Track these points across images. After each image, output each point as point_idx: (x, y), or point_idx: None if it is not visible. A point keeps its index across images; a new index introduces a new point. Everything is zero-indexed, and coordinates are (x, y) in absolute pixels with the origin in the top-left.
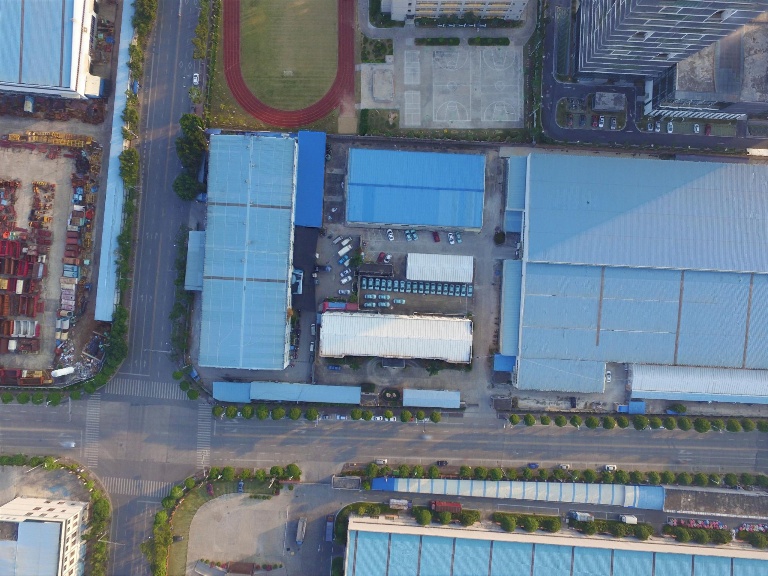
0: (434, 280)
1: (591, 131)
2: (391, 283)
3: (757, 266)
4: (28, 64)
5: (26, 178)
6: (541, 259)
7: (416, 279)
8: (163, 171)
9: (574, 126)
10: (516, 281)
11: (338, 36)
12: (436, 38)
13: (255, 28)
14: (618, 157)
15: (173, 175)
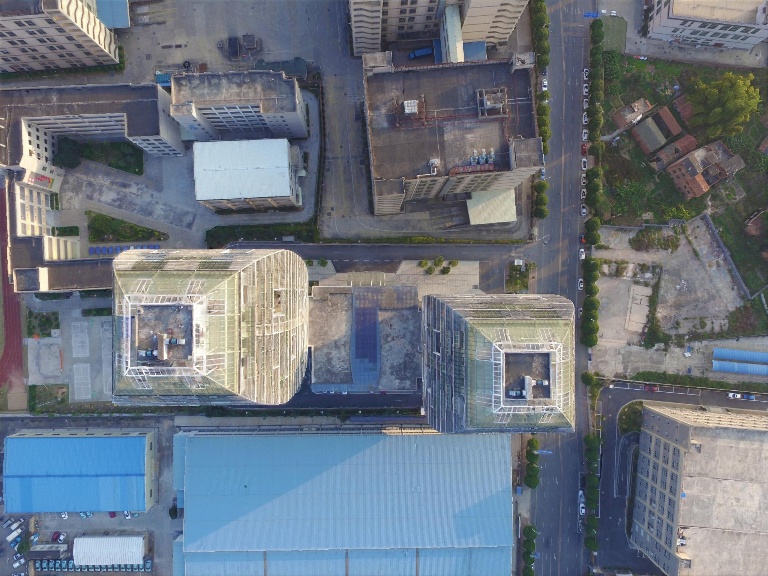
0: (103, 564)
1: None
2: (65, 564)
3: (419, 542)
4: None
5: None
6: (197, 550)
7: (84, 564)
8: None
9: None
10: (183, 564)
11: (4, 310)
12: (103, 309)
13: None
14: (277, 436)
15: None
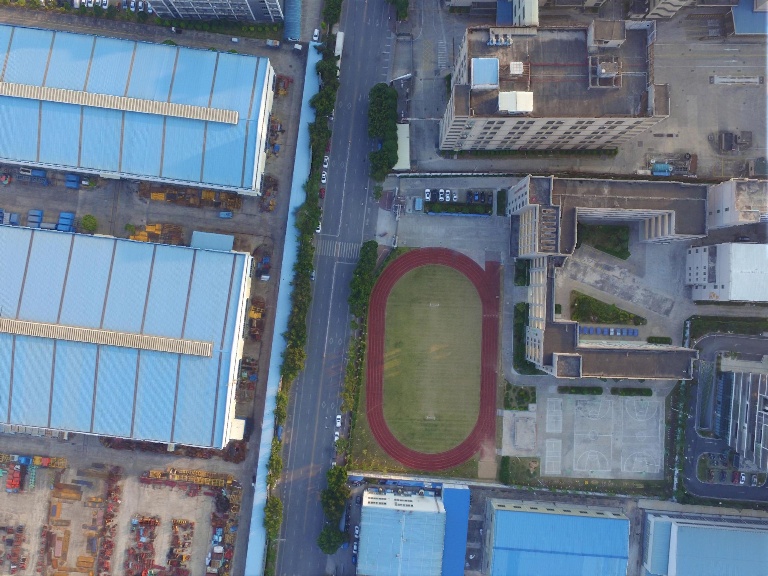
0: None
1: (731, 487)
2: None
3: None
4: (180, 424)
5: (165, 515)
6: None
7: None
8: (302, 512)
9: (714, 481)
10: None
11: (481, 380)
12: (579, 387)
13: (399, 370)
14: (764, 532)
15: (312, 516)
